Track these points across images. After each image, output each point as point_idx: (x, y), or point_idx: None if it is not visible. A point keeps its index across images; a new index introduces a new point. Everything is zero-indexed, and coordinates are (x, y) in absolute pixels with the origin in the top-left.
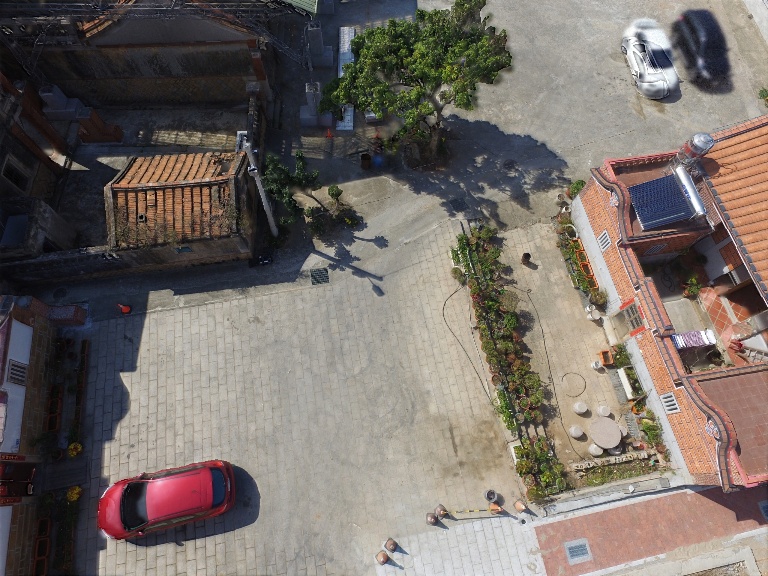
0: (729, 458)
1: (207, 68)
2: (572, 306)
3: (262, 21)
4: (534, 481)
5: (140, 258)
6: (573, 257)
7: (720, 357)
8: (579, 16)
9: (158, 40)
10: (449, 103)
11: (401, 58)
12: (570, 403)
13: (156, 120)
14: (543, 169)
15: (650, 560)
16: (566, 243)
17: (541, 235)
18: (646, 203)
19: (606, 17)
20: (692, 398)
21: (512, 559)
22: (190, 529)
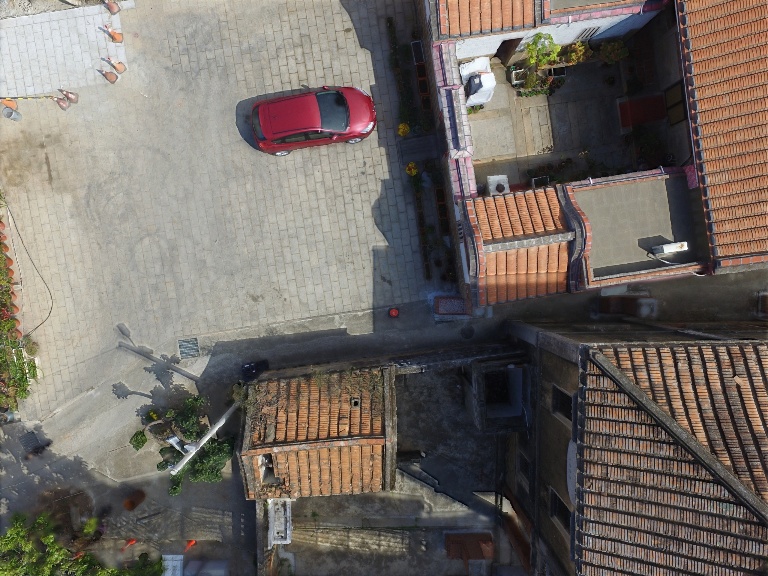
0: None
1: None
2: None
3: None
4: None
5: None
6: None
7: None
8: None
9: None
10: None
11: None
12: None
13: (409, 568)
14: None
15: None
16: None
17: None
18: None
19: None
20: None
21: (1, 62)
22: None
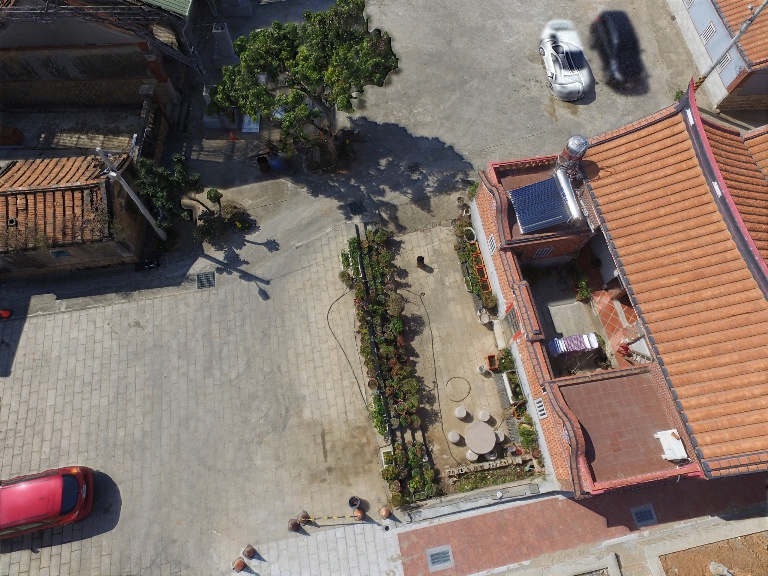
0: (579, 464)
1: (105, 71)
2: (464, 310)
3: (144, 24)
4: (399, 487)
5: (17, 262)
6: (469, 260)
7: (606, 361)
8: (500, 18)
9: (48, 43)
10: (334, 106)
11: (282, 61)
12: (452, 408)
13: (59, 123)
14: (448, 172)
15: (513, 567)
16: (463, 246)
17: (440, 238)
18: (527, 206)
19: (527, 18)
20: (551, 403)
21: (371, 566)
22: (47, 536)
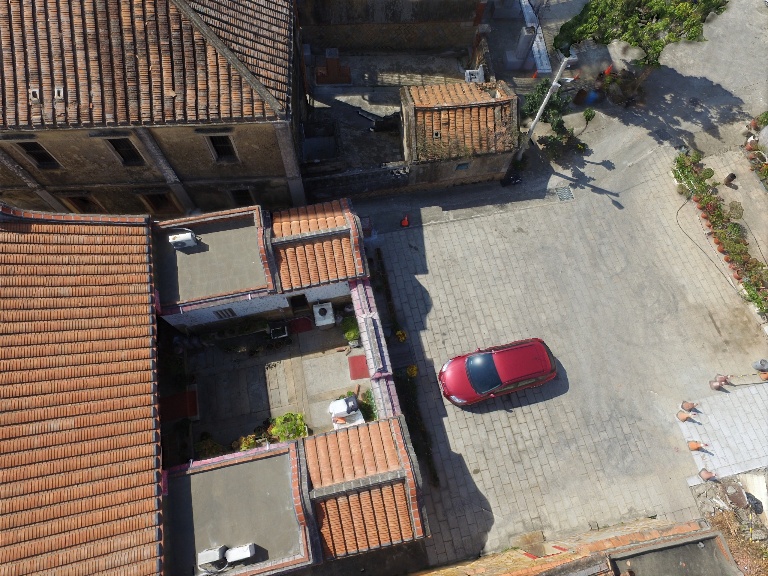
0: None
1: (434, 14)
2: None
3: None
4: None
5: (422, 175)
6: None
7: None
8: None
9: None
10: (678, 37)
11: None
12: None
13: (376, 64)
14: (724, 105)
15: None
16: (759, 166)
17: (734, 161)
18: None
19: None
20: None
21: None
22: (514, 399)
